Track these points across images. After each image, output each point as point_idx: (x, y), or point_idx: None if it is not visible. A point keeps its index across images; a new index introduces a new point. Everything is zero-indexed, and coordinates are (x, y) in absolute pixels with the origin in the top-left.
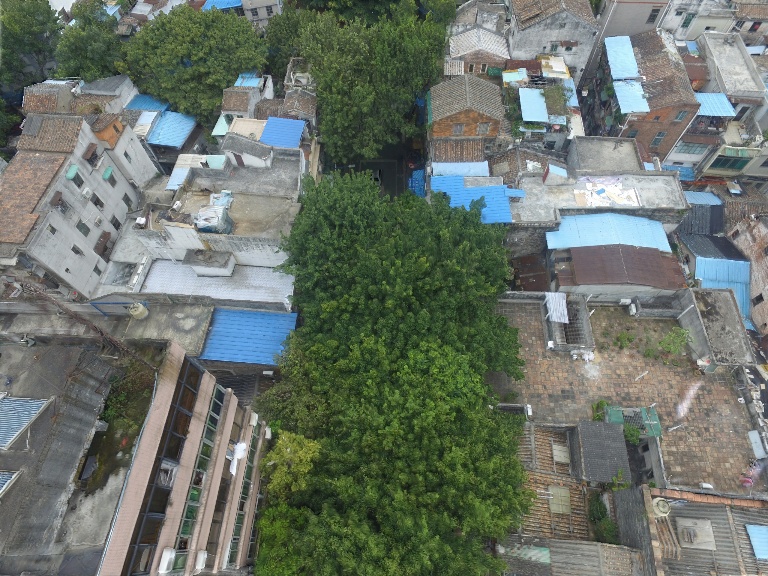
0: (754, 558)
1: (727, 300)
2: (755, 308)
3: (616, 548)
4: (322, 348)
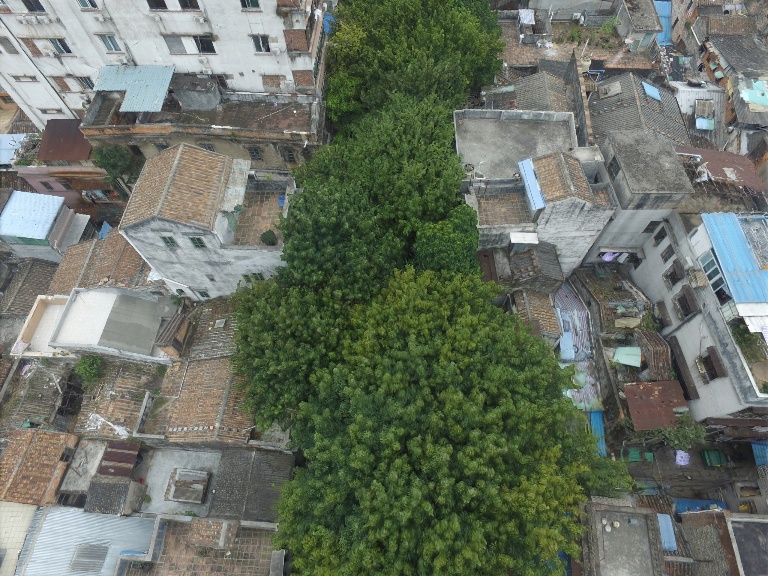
0: (646, 96)
1: (647, 2)
2: (673, 30)
3: None
4: (363, 3)
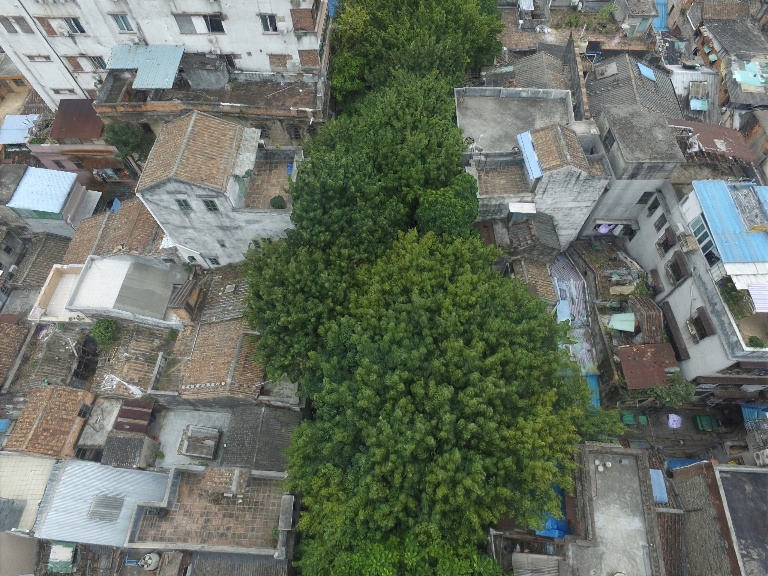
0: (641, 76)
1: None
2: (670, 17)
3: (554, 58)
4: None
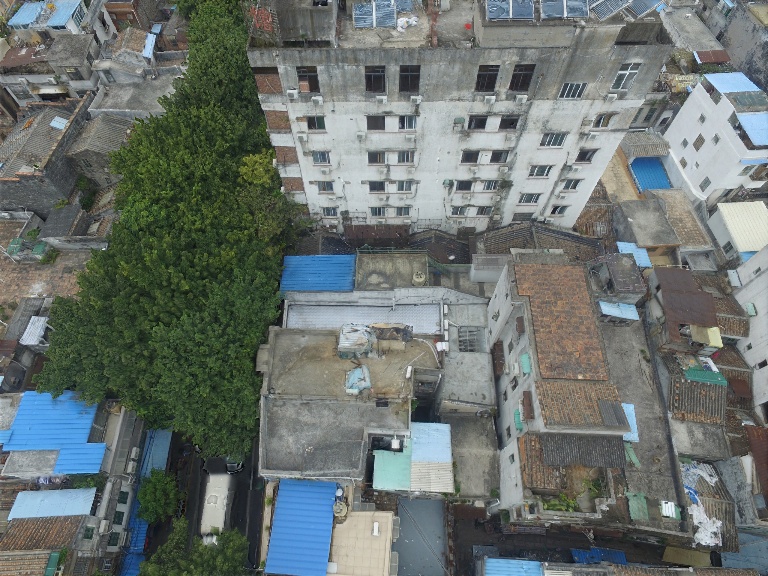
0: None
1: None
2: None
3: None
4: (240, 235)
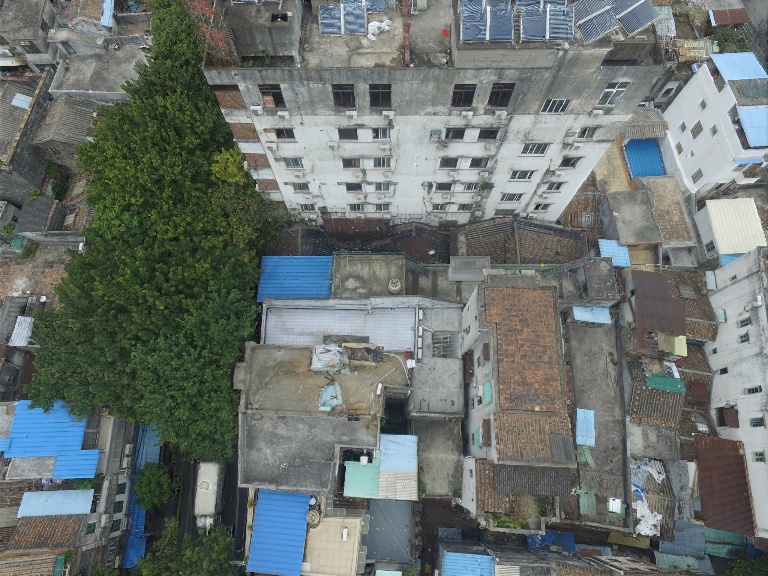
0: None
1: None
2: None
3: None
4: (215, 241)
